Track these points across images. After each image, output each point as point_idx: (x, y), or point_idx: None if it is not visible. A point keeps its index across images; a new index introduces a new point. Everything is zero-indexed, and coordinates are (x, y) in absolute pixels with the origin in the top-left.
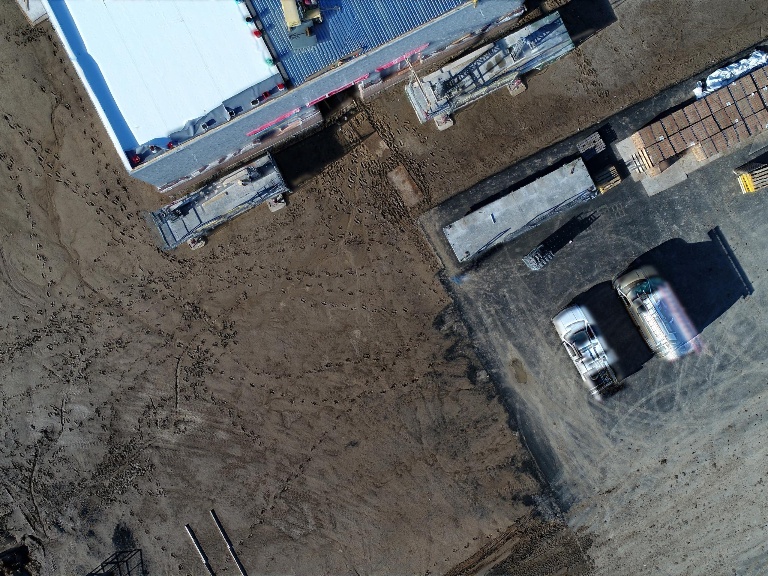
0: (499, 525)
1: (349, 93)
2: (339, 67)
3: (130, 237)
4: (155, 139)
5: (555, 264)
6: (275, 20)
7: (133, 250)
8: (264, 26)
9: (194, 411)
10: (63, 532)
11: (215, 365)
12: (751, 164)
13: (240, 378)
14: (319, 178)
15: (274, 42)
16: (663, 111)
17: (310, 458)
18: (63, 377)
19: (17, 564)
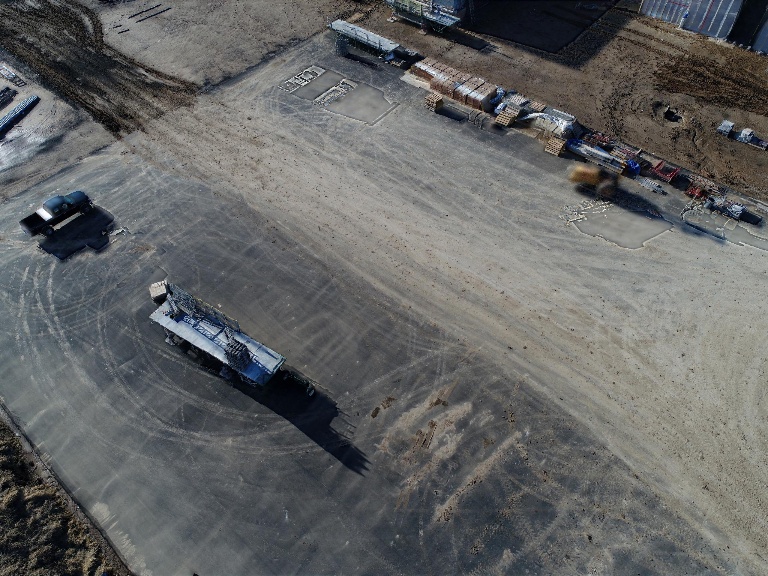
0: (189, 79)
1: None
2: None
3: None
4: None
5: (344, 60)
6: None
7: None
8: None
9: None
10: None
11: None
12: None
13: (239, 2)
14: None
15: None
16: None
17: None
18: None
19: None
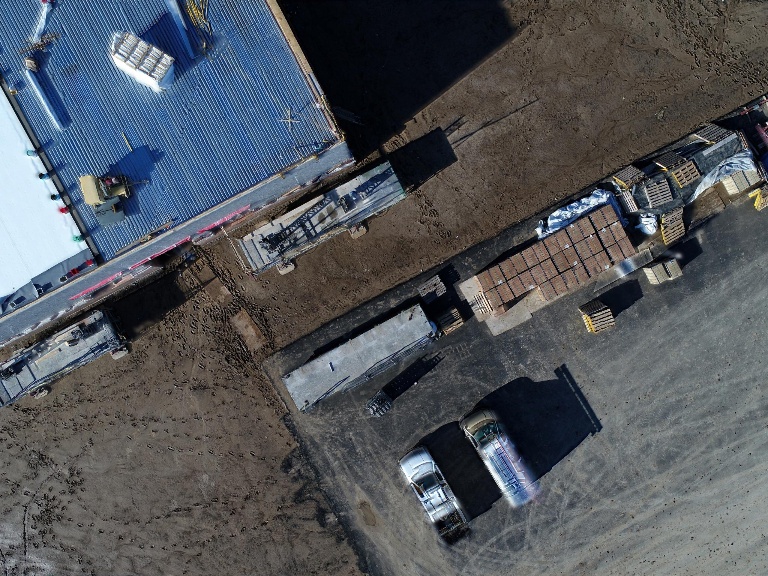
0: None
1: None
2: (146, 243)
3: None
4: None
5: (401, 406)
6: (83, 194)
7: None
8: (72, 201)
9: (43, 558)
10: None
11: (63, 512)
12: (595, 303)
13: (88, 525)
14: (161, 324)
15: (83, 217)
16: (506, 250)
17: None
18: None
19: None
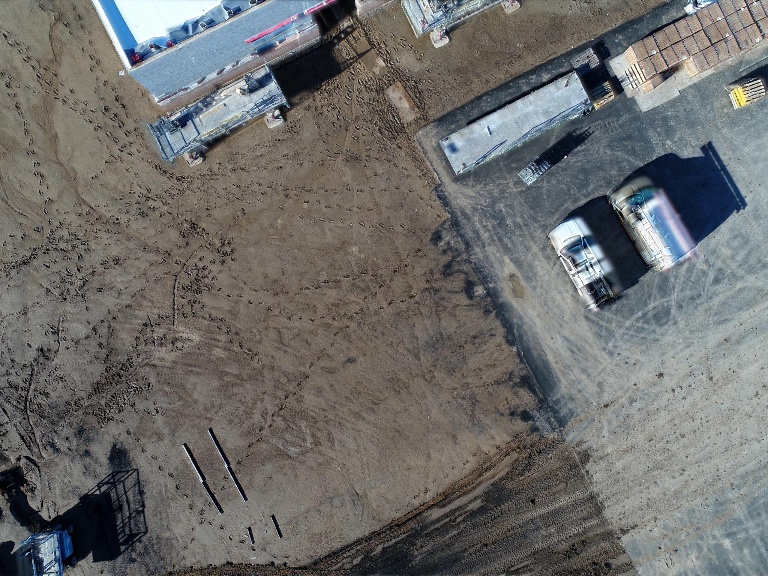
0: (498, 441)
1: (346, 10)
2: None
3: (128, 154)
4: (154, 38)
5: (551, 179)
6: None
7: (131, 167)
8: None
9: (192, 329)
10: (59, 452)
11: (213, 282)
12: (742, 80)
13: (238, 295)
14: (316, 95)
15: None
16: (655, 28)
17: (308, 375)
18: (60, 295)
19: (12, 486)
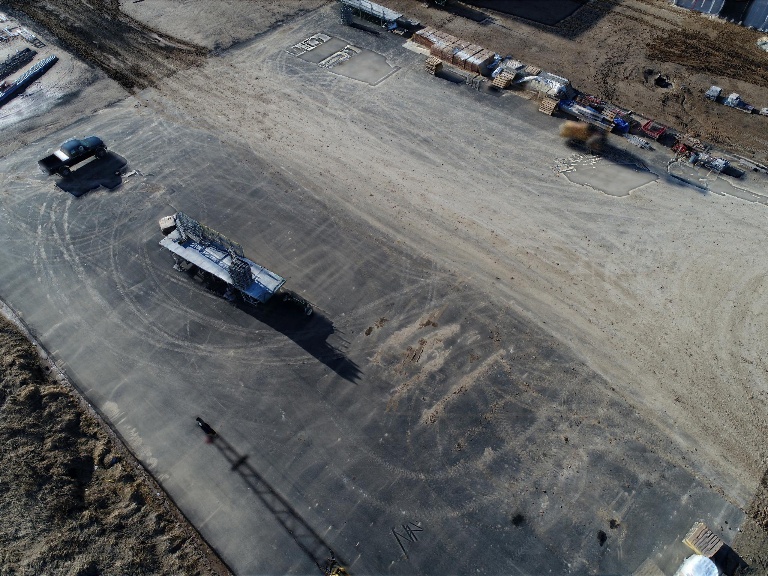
0: None
1: None
2: None
3: None
4: None
5: None
6: None
7: None
8: None
9: None
10: None
11: None
12: None
13: None
14: None
15: None
16: None
17: None
18: None
19: None
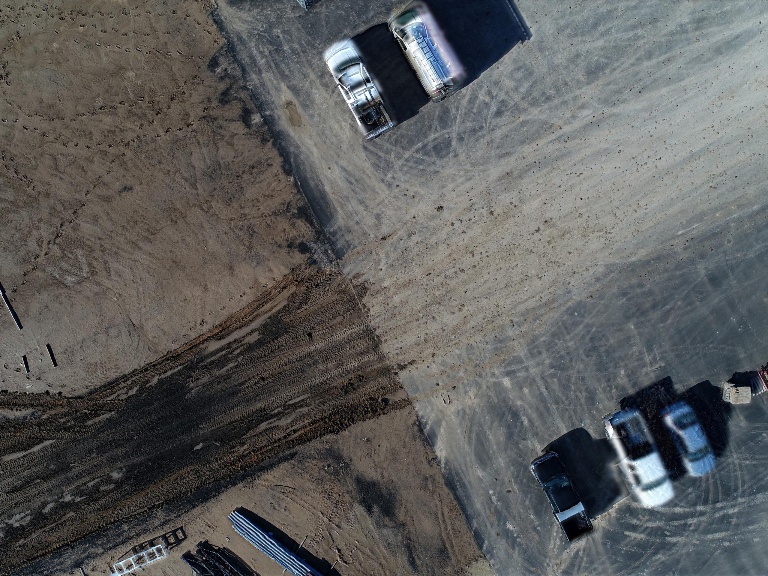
0: (275, 274)
1: None
2: None
3: None
4: None
5: (330, 5)
6: None
7: None
8: None
9: None
10: None
11: None
12: None
13: (13, 120)
14: None
15: None
16: None
17: (84, 204)
18: None
19: None
